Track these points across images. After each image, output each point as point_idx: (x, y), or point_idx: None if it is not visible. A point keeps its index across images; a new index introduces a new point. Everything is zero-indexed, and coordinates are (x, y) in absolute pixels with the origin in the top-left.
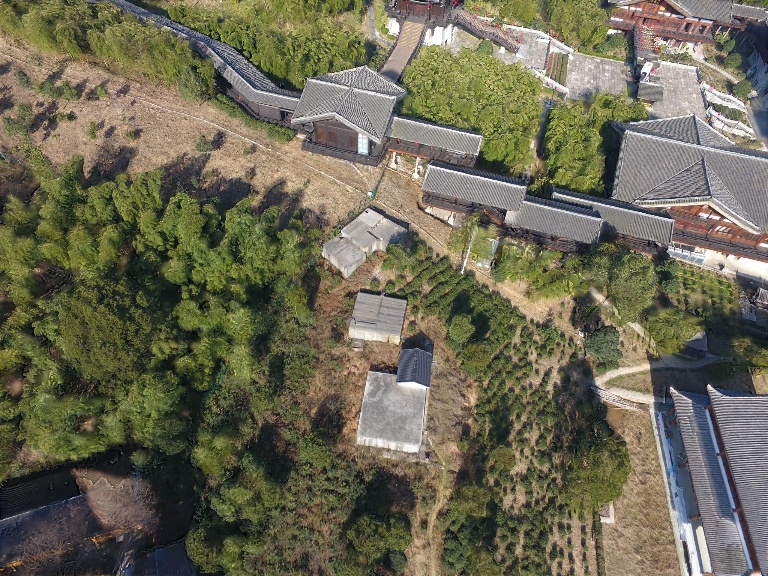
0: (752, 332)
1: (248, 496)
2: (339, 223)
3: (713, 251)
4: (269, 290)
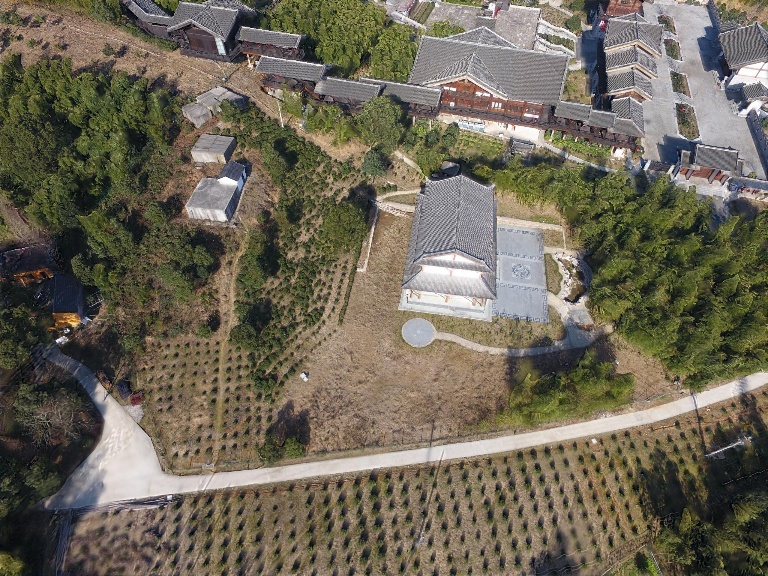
0: None
1: (112, 238)
2: (196, 94)
3: (498, 126)
4: (147, 139)
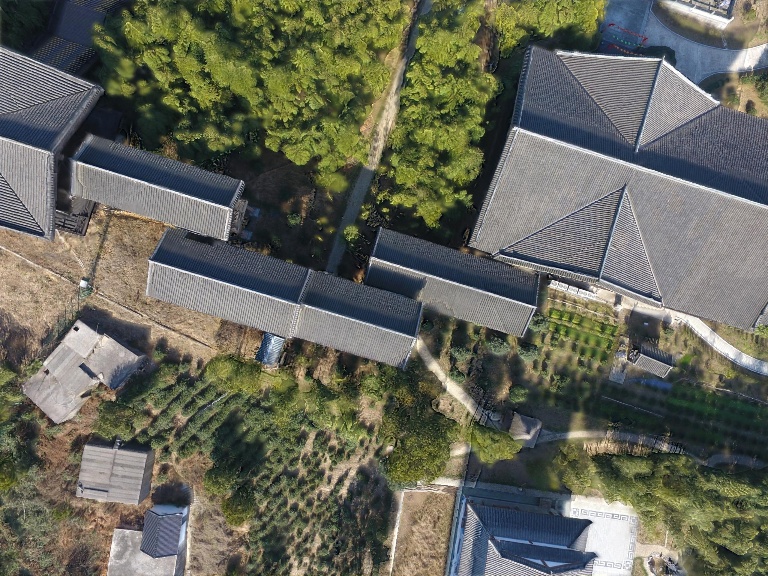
0: (609, 402)
1: None
2: (38, 352)
3: None
4: None
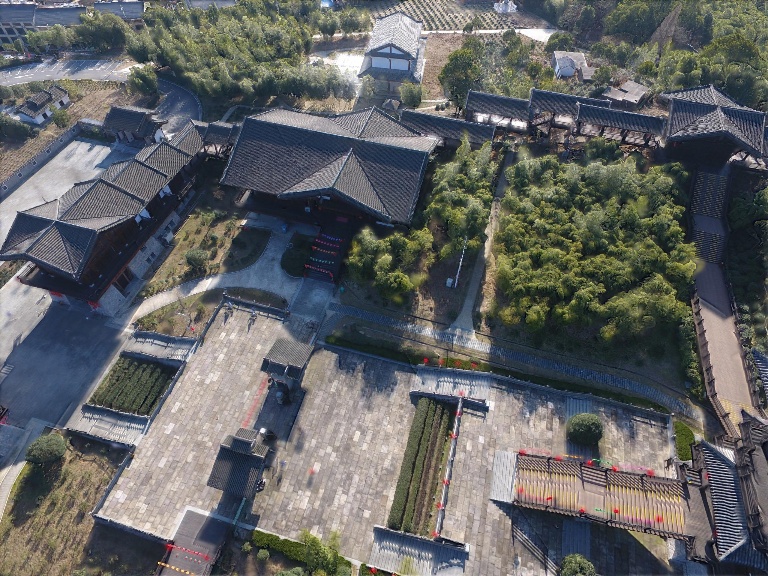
0: None
1: None
2: None
3: None
4: None
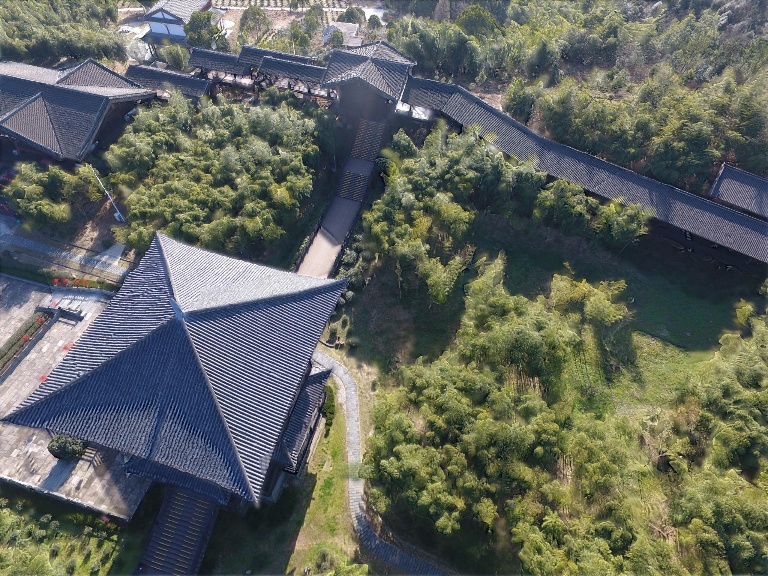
0: None
1: None
2: None
3: None
4: None
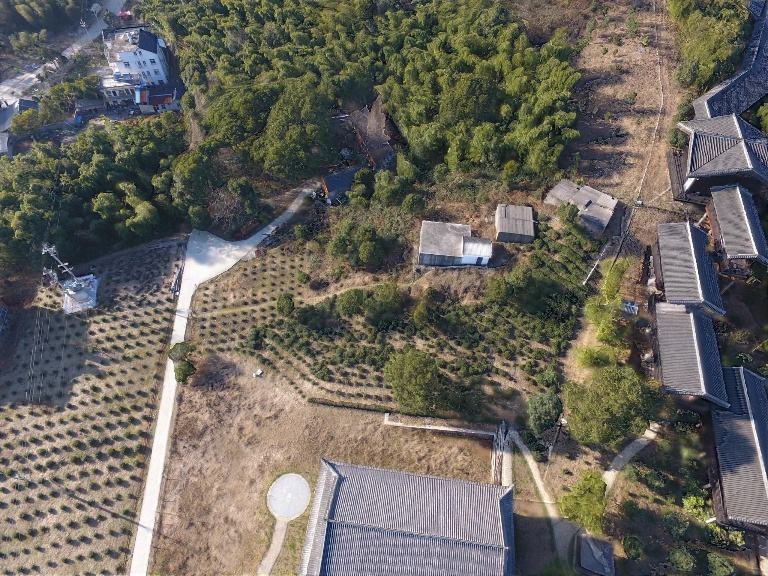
0: None
1: (385, 184)
2: None
3: None
4: None
